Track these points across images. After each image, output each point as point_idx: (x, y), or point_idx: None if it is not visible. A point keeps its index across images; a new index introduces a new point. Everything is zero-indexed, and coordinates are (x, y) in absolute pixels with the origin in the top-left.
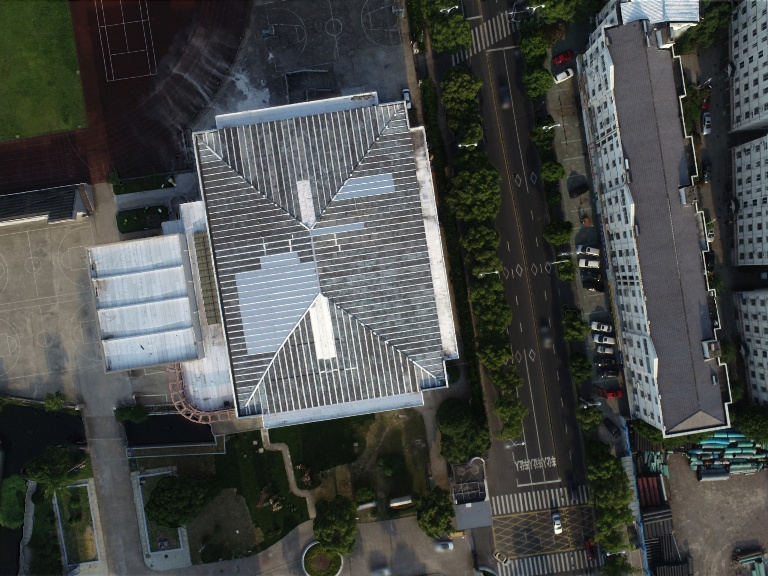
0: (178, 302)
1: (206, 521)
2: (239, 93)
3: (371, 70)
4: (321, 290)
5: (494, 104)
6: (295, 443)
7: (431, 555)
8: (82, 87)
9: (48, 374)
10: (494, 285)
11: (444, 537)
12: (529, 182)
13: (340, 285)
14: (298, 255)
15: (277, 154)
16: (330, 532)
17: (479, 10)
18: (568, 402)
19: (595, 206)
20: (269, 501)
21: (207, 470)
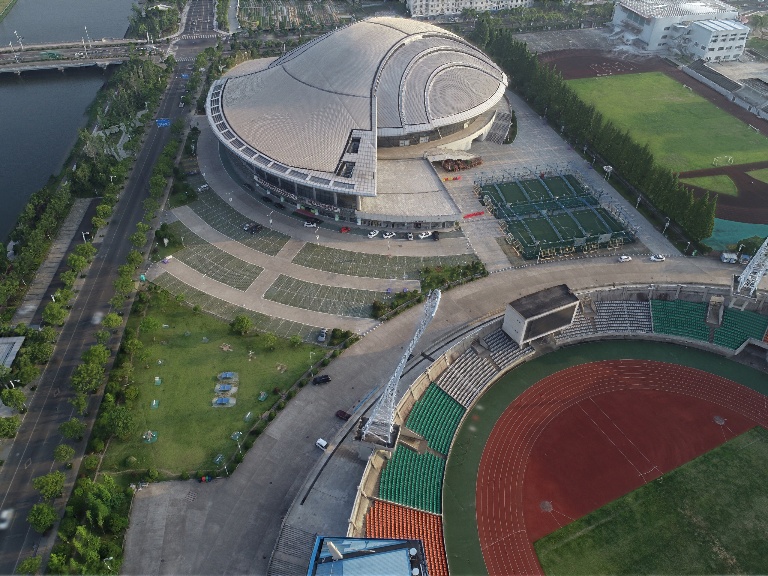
0: None
1: None
2: None
3: None
4: None
5: None
6: None
7: None
8: None
9: None
10: None
11: None
12: None
13: None
14: None
15: None
16: None
17: None
18: None
19: None
20: (759, 38)
21: None
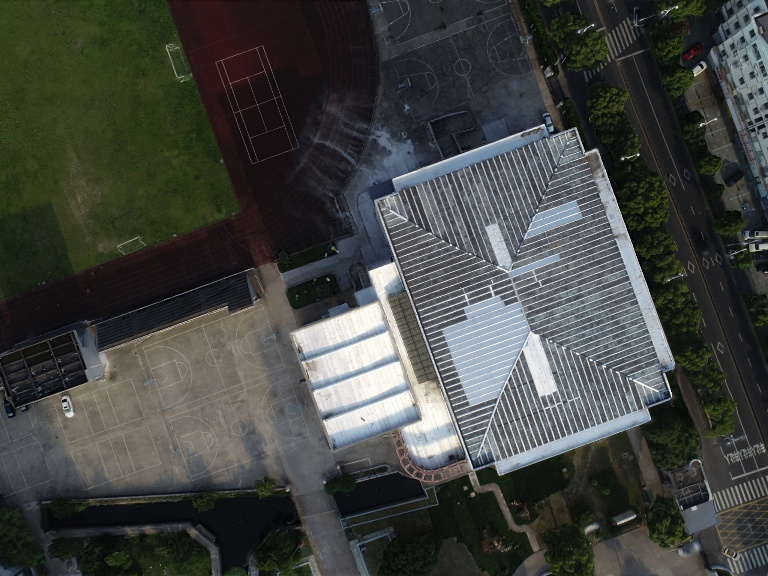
0: (389, 368)
1: (434, 575)
2: (383, 150)
3: (507, 101)
4: (531, 328)
5: (634, 110)
6: (505, 481)
7: (660, 564)
8: (229, 175)
9: (249, 461)
10: (680, 288)
11: (676, 545)
12: (683, 179)
13: (548, 320)
14: (501, 299)
15: (460, 204)
16: (572, 563)
17: (601, 22)
18: (765, 387)
19: (753, 190)
20: (493, 543)
21: (423, 525)
